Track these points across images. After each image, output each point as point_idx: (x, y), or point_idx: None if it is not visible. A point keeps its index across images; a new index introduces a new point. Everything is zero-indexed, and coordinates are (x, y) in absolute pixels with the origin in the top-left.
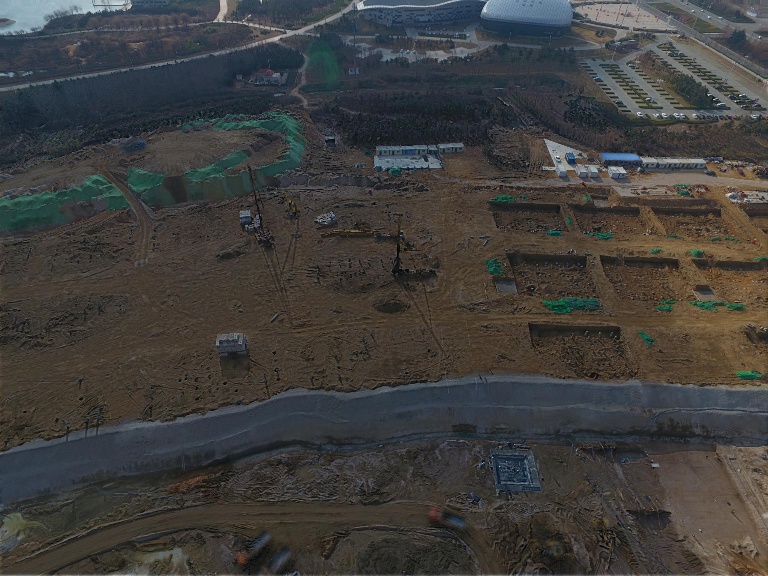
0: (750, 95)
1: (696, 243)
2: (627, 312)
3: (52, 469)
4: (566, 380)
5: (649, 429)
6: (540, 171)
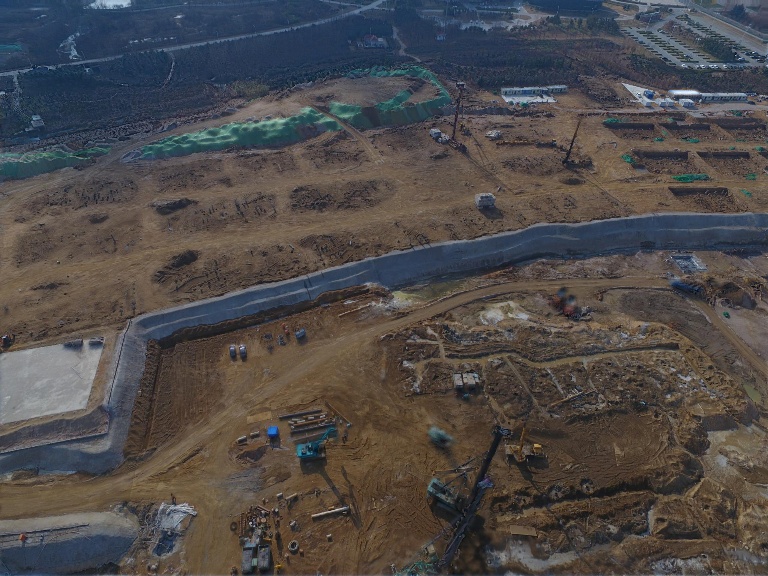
0: (760, 53)
1: (757, 144)
2: (728, 180)
3: (410, 267)
4: (707, 213)
5: (761, 239)
6: (630, 103)
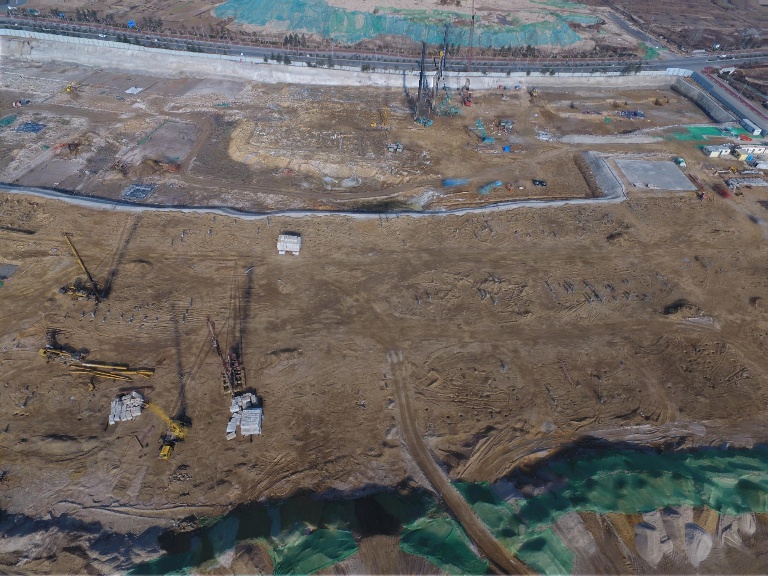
0: None
1: None
2: None
3: None
4: (58, 198)
5: None
6: None
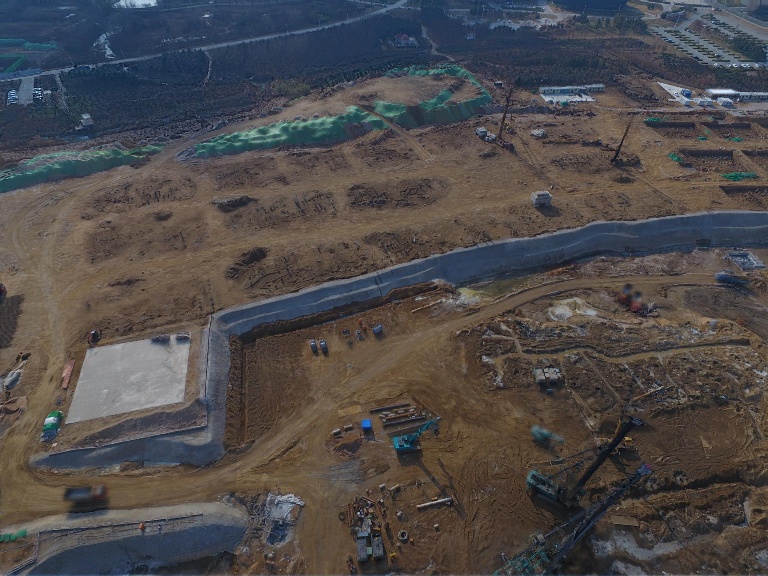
0: None
1: None
2: None
3: (475, 264)
4: (761, 211)
5: None
6: (668, 102)
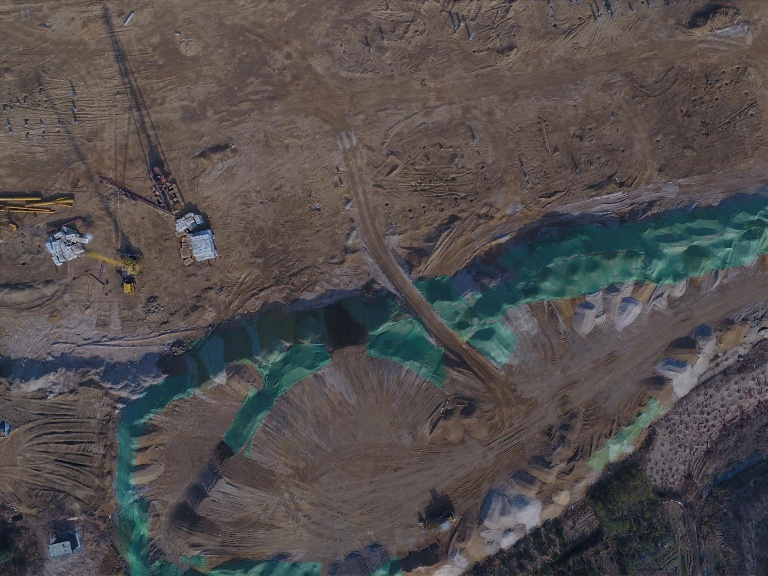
0: None
1: None
2: None
3: None
4: None
5: None
6: None
